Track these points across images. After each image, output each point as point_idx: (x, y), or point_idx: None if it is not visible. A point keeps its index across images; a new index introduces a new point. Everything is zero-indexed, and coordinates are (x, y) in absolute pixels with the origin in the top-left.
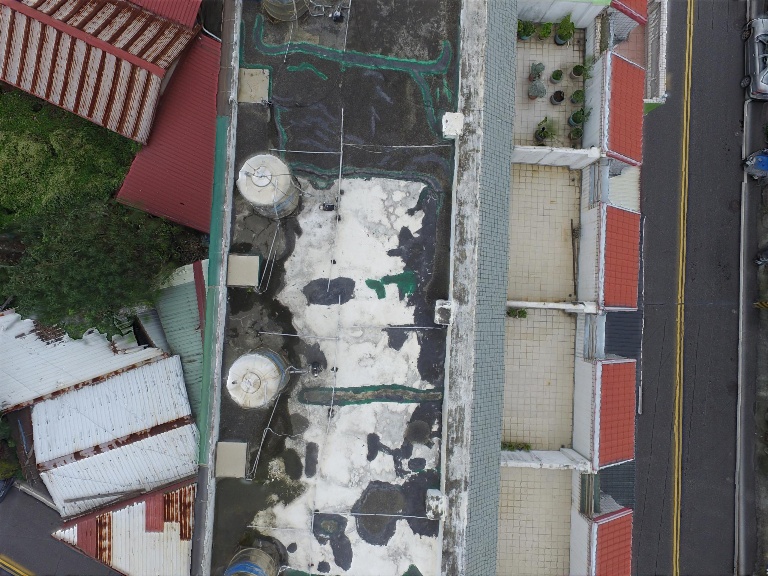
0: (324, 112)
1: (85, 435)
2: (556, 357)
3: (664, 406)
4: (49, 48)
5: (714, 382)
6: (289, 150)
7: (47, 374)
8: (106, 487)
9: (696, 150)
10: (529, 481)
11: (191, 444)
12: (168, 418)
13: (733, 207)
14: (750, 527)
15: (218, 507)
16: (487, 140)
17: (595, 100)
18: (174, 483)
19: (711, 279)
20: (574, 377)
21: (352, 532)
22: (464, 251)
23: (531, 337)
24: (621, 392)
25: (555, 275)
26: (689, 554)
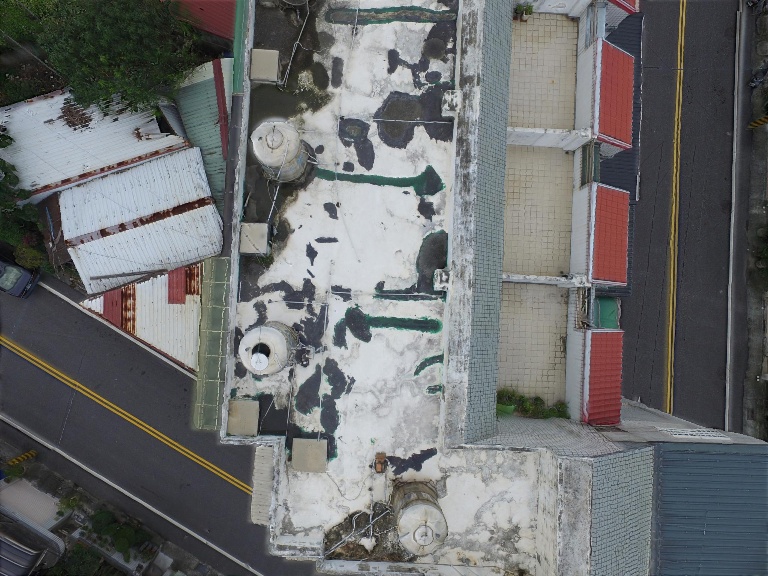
0: None
1: (110, 215)
2: (560, 58)
3: (661, 223)
4: None
5: (709, 200)
6: None
7: (74, 158)
8: (130, 266)
9: None
10: (534, 169)
11: (211, 225)
12: (189, 199)
13: (728, 35)
14: (742, 337)
15: (253, 107)
16: None
17: None
18: (195, 263)
19: (707, 103)
20: (576, 76)
21: (374, 136)
22: None
23: (536, 39)
24: (620, 78)
25: None
26: (683, 362)
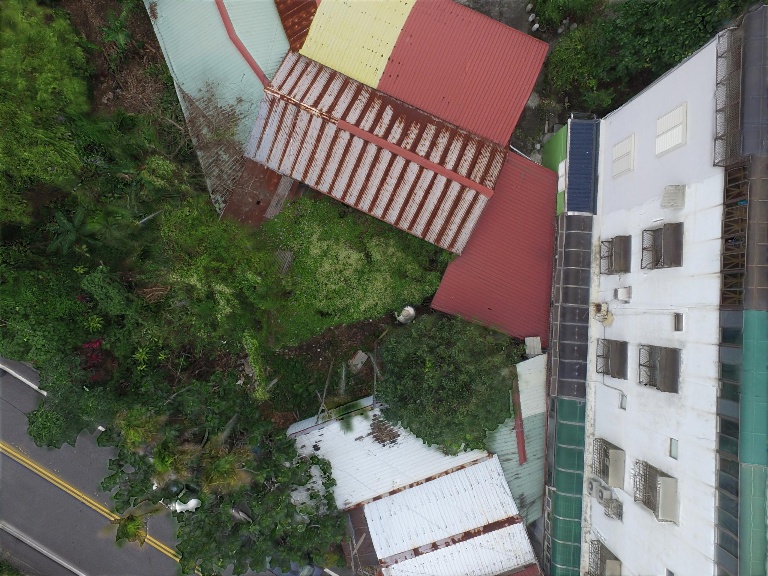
0: None
1: (420, 532)
2: None
3: None
4: (381, 169)
5: None
6: None
7: (384, 474)
8: None
9: None
10: None
11: (517, 541)
12: (498, 517)
13: None
14: None
15: None
16: None
17: None
18: None
19: None
20: None
21: None
22: None
23: None
24: None
25: None
26: None
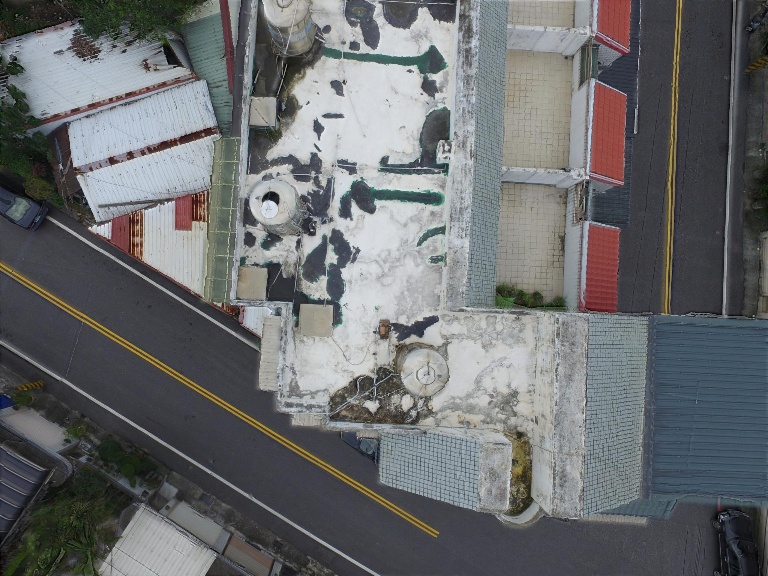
0: None
1: (119, 144)
2: None
3: (659, 165)
4: None
5: (706, 142)
6: None
7: (83, 88)
8: (138, 195)
9: None
10: (534, 73)
11: None
12: (196, 129)
13: None
14: (738, 277)
15: None
16: None
17: None
18: None
19: (705, 47)
20: None
21: (379, 17)
22: None
23: None
24: None
25: None
26: (680, 301)
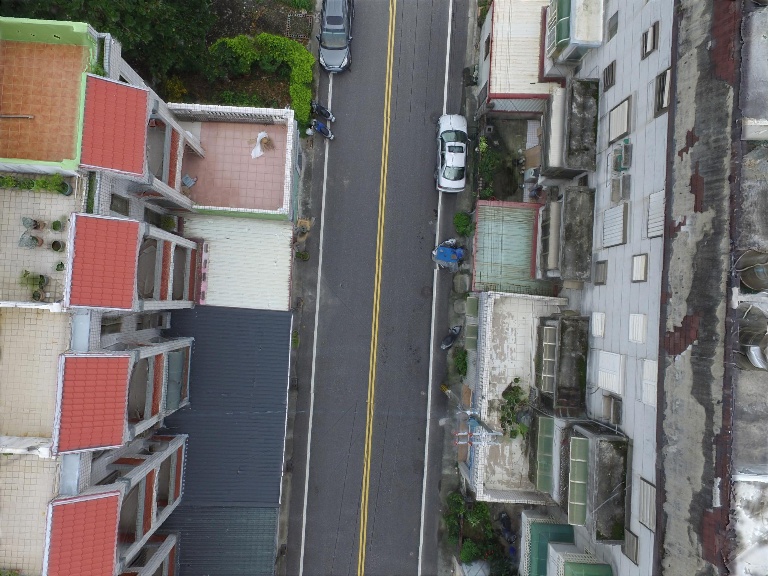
0: None
1: None
2: None
3: (353, 484)
4: None
5: (401, 461)
6: None
7: None
8: None
9: (390, 238)
10: None
11: None
12: None
13: (425, 293)
14: None
15: None
16: None
17: None
18: None
19: (401, 362)
20: None
21: None
22: None
23: (29, 470)
24: (91, 526)
25: None
26: None
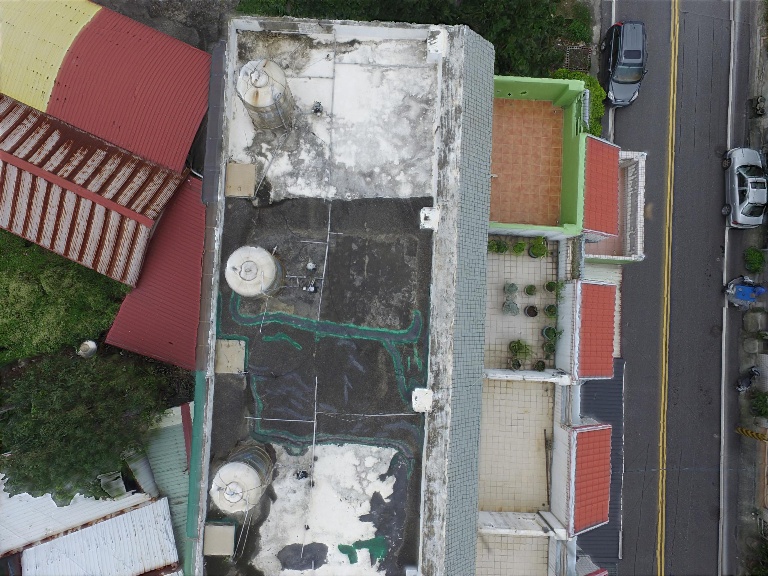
0: (298, 381)
1: None
2: (530, 566)
3: (647, 530)
4: (40, 197)
5: (696, 507)
6: (264, 418)
7: (36, 521)
8: None
9: (678, 276)
10: None
11: None
12: (155, 565)
13: (714, 332)
14: None
15: None
16: (455, 414)
17: (567, 322)
18: None
19: (693, 404)
20: None
21: None
22: (432, 528)
23: (505, 546)
24: None
25: (529, 484)
26: None
